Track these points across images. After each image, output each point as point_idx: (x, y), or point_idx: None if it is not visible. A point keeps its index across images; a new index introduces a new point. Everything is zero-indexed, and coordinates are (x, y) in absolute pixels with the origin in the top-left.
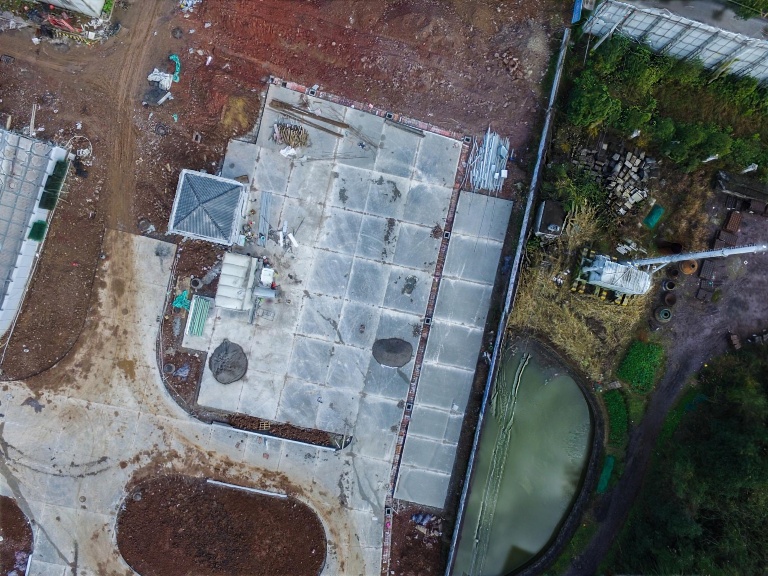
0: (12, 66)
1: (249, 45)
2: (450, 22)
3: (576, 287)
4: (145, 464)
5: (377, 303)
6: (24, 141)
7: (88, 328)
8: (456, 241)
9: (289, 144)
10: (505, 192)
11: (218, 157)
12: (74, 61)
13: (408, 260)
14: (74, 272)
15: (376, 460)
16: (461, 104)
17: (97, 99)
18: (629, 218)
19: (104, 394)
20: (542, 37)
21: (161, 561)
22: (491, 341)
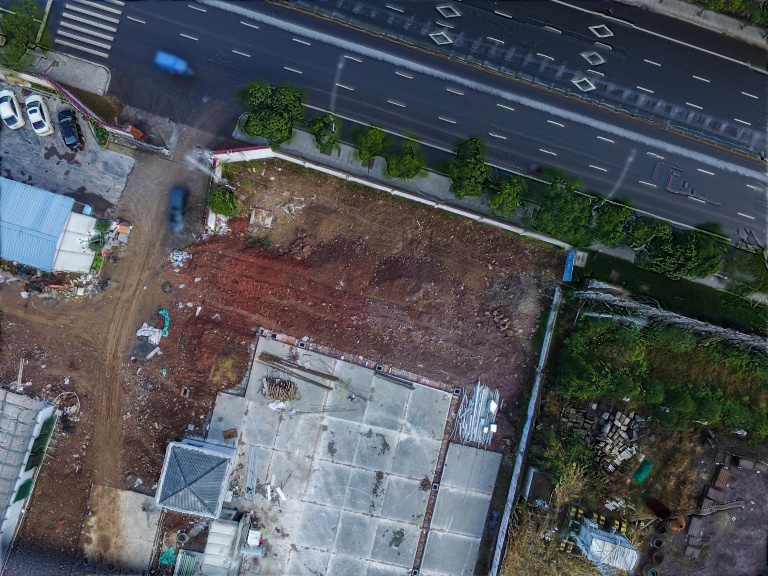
0: (0, 320)
1: (239, 298)
2: (441, 285)
3: (564, 548)
4: None
5: (364, 556)
6: (11, 396)
7: None
8: (444, 494)
9: (278, 399)
10: (494, 445)
11: (206, 410)
12: (63, 315)
13: (396, 513)
14: (60, 529)
15: None
16: (451, 357)
17: (85, 353)
18: (618, 476)
19: None
20: (533, 293)
21: None
22: None
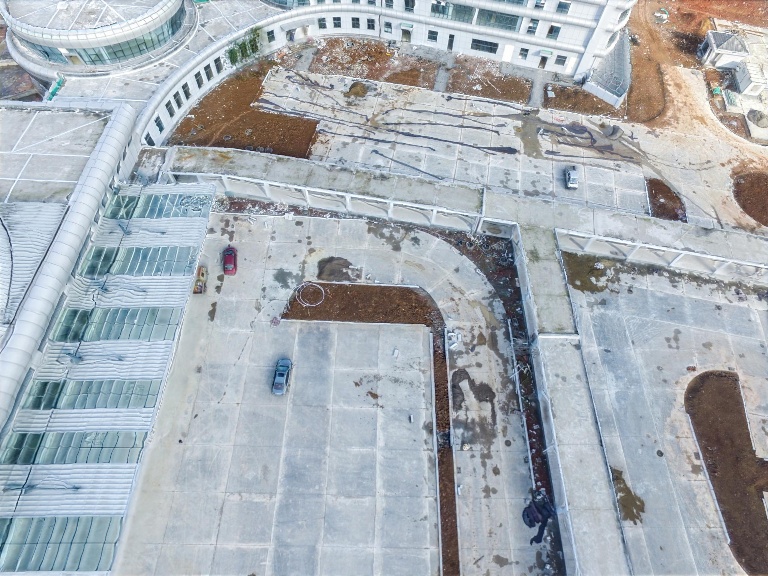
0: None
1: (696, 7)
2: None
3: None
4: (736, 165)
5: None
6: None
7: (668, 102)
8: None
9: None
10: None
11: None
12: None
13: None
14: (652, 78)
15: None
16: None
17: (631, 21)
18: None
19: (692, 131)
20: None
21: None
22: None
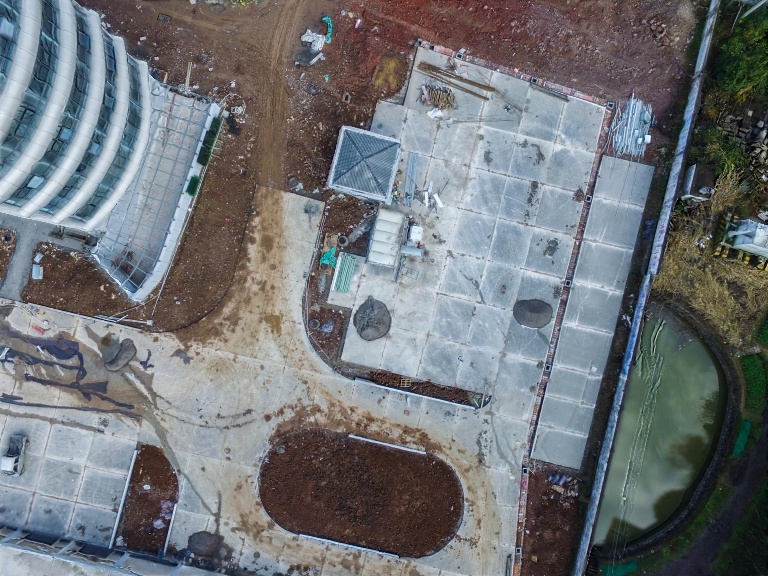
0: (169, 25)
1: (399, 8)
2: None
3: (719, 252)
4: (289, 418)
5: (519, 264)
6: (179, 98)
7: (237, 282)
8: (598, 205)
9: (437, 106)
10: (647, 157)
11: (366, 117)
12: (229, 21)
13: (550, 223)
14: (226, 227)
15: (514, 420)
16: (605, 70)
17: (251, 58)
18: None
19: (250, 348)
20: (688, 5)
21: (303, 514)
22: (631, 304)
